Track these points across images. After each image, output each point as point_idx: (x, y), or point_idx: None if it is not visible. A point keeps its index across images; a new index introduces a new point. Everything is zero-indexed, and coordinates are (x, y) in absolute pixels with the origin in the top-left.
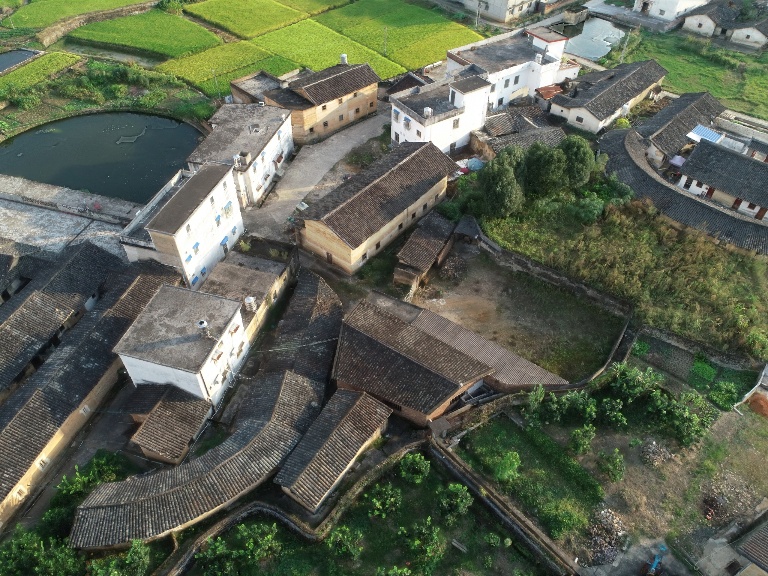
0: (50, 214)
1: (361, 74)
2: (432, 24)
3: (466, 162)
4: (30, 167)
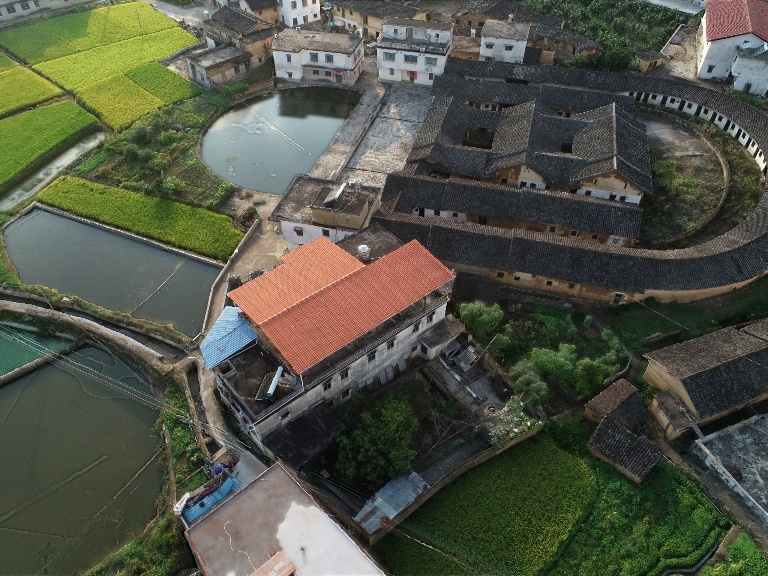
0: (371, 134)
1: None
2: (90, 17)
3: (326, 7)
4: (302, 159)
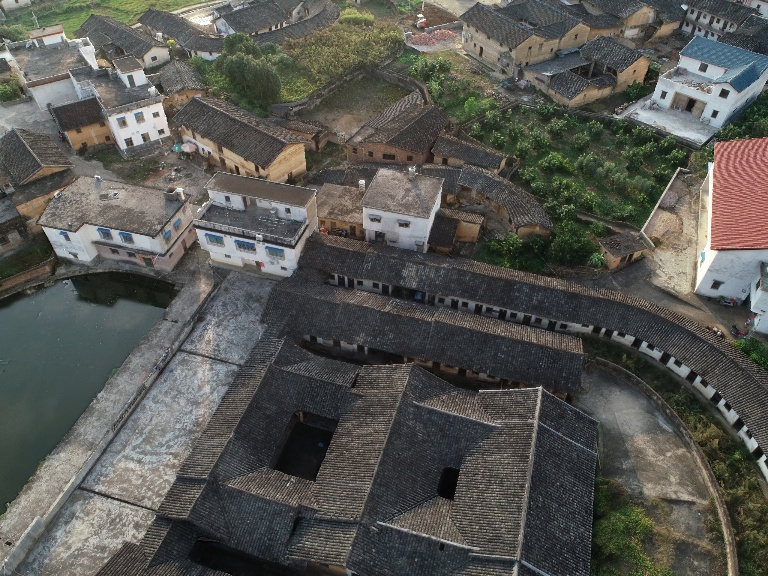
0: (153, 395)
1: (29, 135)
2: None
3: None
4: (15, 460)
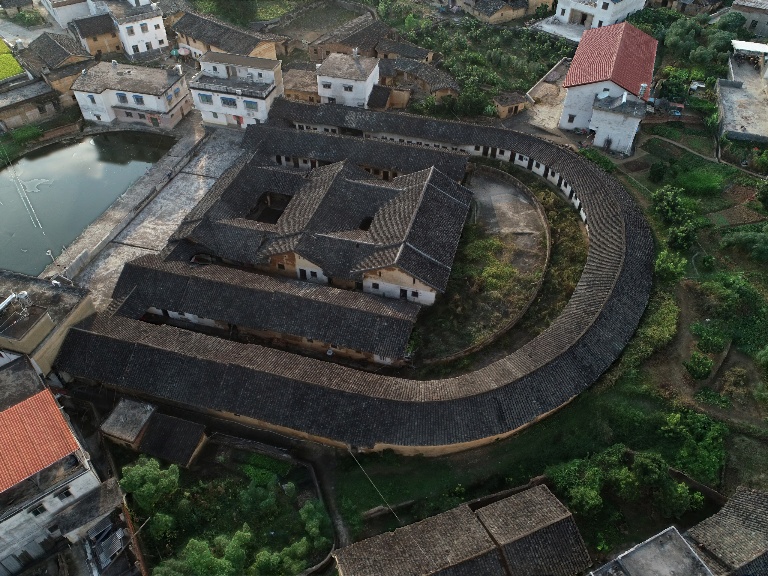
0: (162, 196)
1: (58, 37)
2: None
3: None
4: (65, 229)
